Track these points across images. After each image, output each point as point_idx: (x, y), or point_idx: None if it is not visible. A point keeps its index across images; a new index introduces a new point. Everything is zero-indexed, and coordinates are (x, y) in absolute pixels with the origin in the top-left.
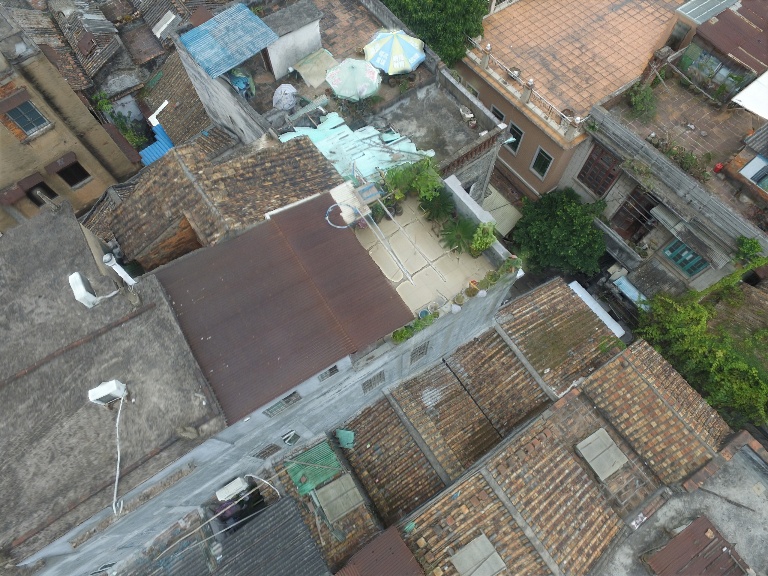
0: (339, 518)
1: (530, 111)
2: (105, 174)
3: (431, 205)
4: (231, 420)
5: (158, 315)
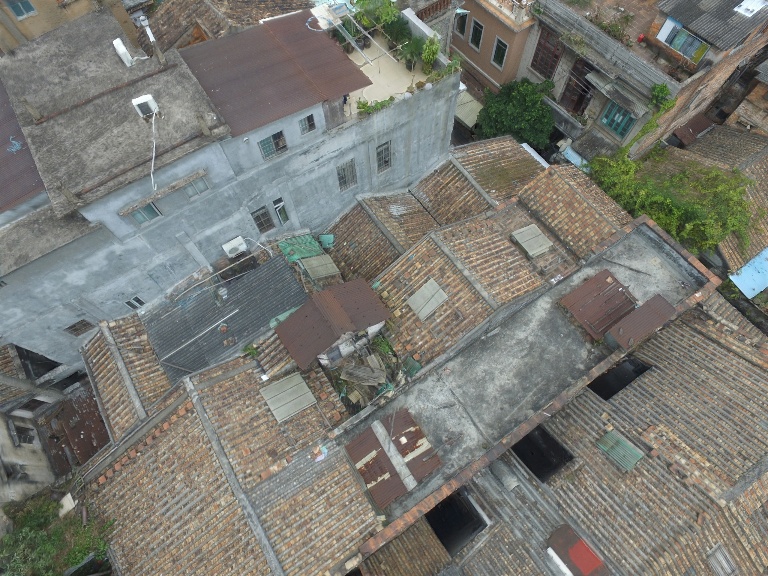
0: (320, 277)
1: (487, 2)
2: None
3: (391, 30)
4: (234, 135)
5: (179, 70)
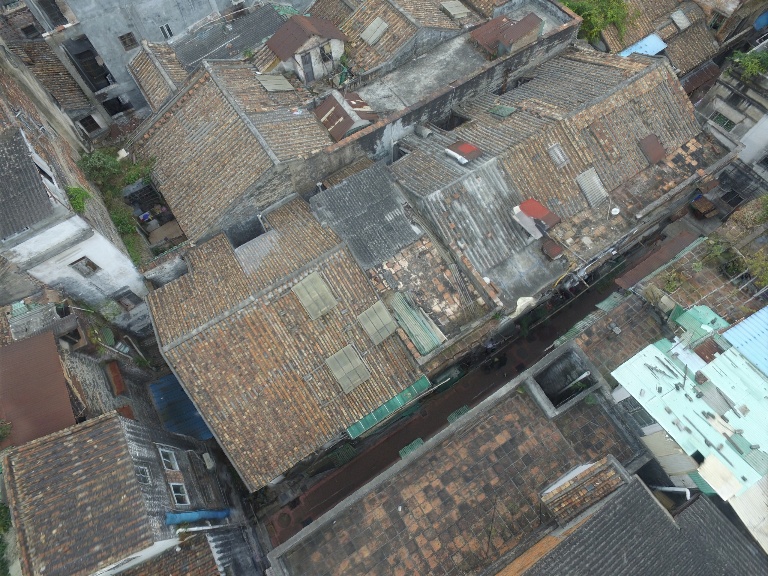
0: None
1: None
2: None
3: None
4: None
5: None
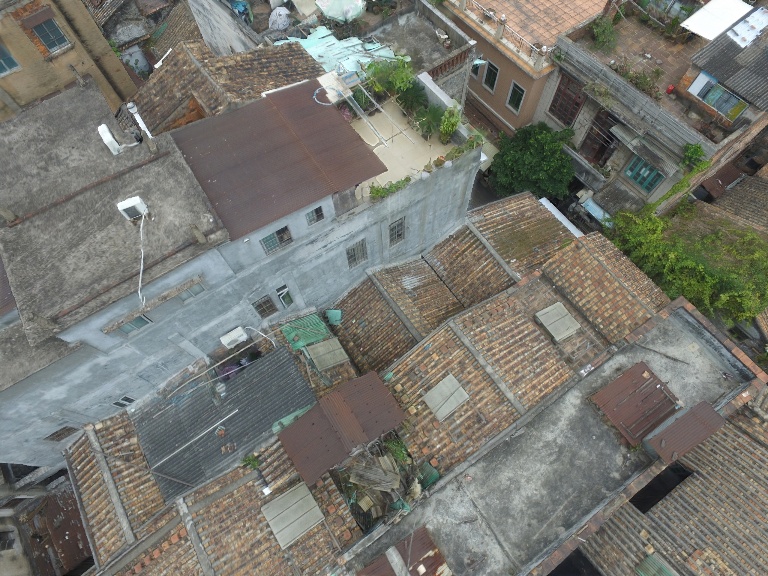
0: (327, 368)
1: (504, 46)
2: (117, 100)
3: (406, 97)
4: (233, 237)
5: (172, 160)
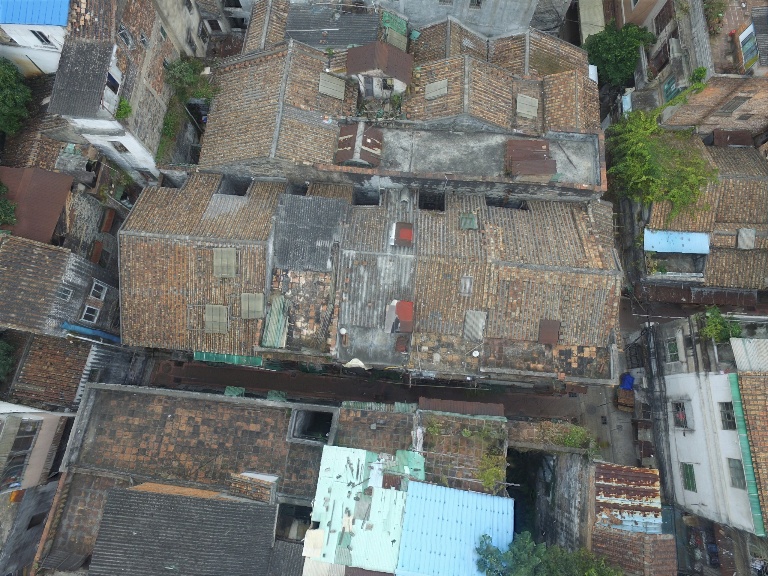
0: (392, 44)
1: None
2: None
3: None
4: None
5: None
